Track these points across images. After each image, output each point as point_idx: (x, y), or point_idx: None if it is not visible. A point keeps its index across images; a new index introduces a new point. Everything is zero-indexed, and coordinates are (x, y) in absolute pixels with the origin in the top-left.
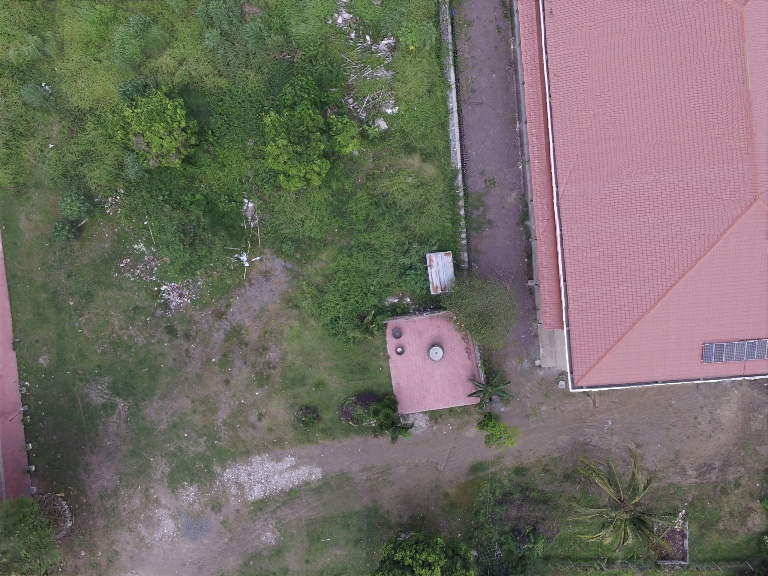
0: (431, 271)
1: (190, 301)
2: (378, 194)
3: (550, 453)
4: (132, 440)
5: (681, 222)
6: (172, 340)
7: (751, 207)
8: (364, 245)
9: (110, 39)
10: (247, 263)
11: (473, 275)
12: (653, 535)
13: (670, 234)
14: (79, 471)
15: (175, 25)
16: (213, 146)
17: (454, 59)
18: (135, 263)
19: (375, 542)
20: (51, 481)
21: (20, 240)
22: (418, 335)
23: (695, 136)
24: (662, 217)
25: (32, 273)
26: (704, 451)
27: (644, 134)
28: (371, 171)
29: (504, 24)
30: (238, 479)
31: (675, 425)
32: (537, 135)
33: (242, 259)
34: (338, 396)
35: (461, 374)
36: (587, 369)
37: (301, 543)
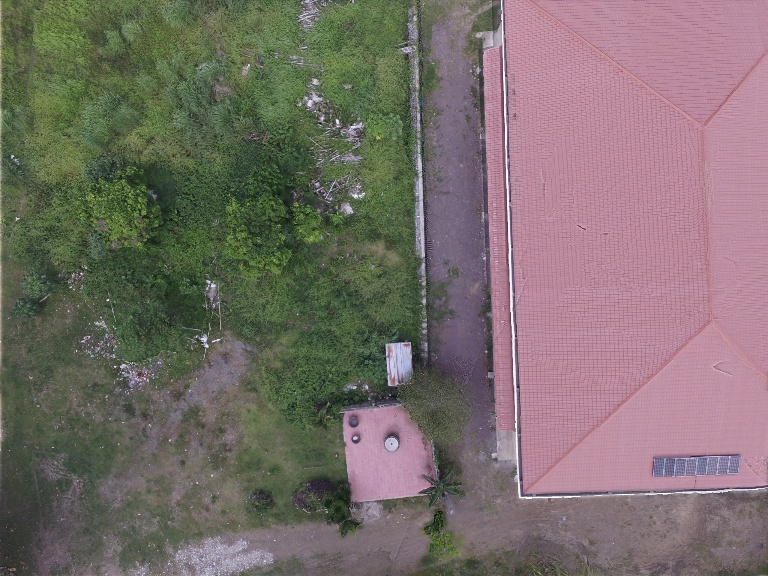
0: (389, 362)
1: (149, 380)
2: (340, 281)
3: (503, 547)
4: (86, 517)
5: (637, 334)
6: (129, 419)
7: (704, 329)
8: (324, 331)
9: (80, 114)
10: (207, 345)
11: (432, 367)
12: None
13: (625, 345)
14: (32, 546)
15: (145, 102)
16: (178, 226)
17: (422, 148)
18: (95, 340)
19: None
20: (3, 555)
21: None
22: (375, 423)
23: None
24: (618, 327)
25: None
26: (658, 551)
27: None
28: (335, 255)
29: (474, 114)
30: (190, 561)
31: (630, 523)
32: (498, 235)
33: (202, 340)
34: (293, 481)
35: (417, 464)
36: (537, 478)
37: None
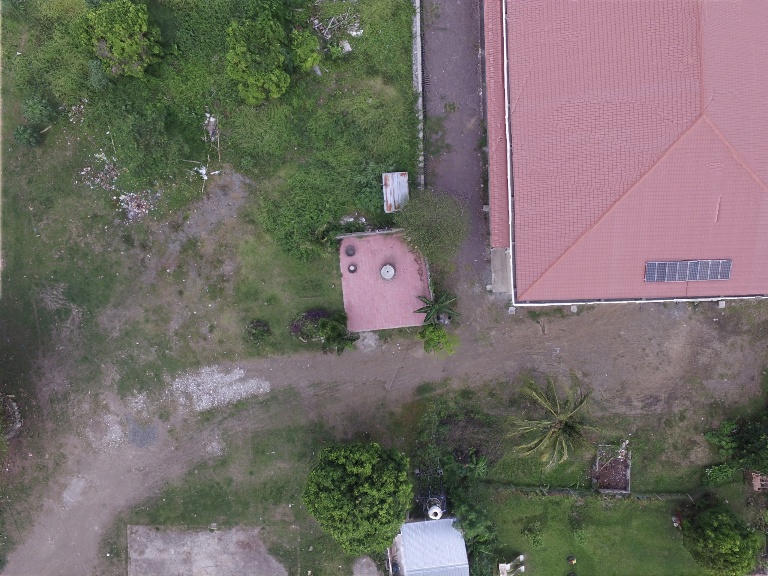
0: (386, 190)
1: (148, 211)
2: (338, 113)
3: (497, 378)
4: (84, 346)
5: (630, 142)
6: (128, 249)
7: (696, 123)
8: (322, 163)
9: None
10: (206, 176)
11: None
12: (583, 441)
13: (619, 153)
14: (31, 374)
15: None
16: (178, 60)
17: None
18: (95, 171)
19: None
20: (2, 382)
21: None
22: (371, 255)
23: (655, 70)
24: (612, 137)
25: None
26: (650, 383)
27: (601, 59)
28: (333, 92)
29: None
30: (187, 389)
31: (623, 356)
32: (494, 55)
33: (201, 172)
34: (290, 312)
35: (412, 295)
36: (530, 283)
37: (246, 455)
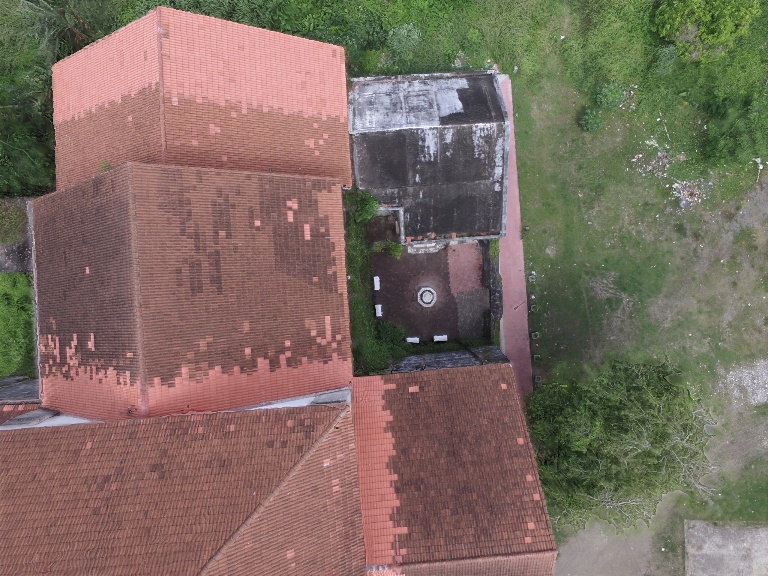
0: None
1: (701, 200)
2: None
3: None
4: (636, 336)
5: None
6: (681, 239)
7: None
8: None
9: None
10: (762, 166)
11: None
12: None
13: None
14: (582, 364)
15: None
16: None
17: None
18: (648, 159)
19: None
20: (554, 372)
21: (531, 129)
22: None
23: None
24: None
25: (542, 163)
26: None
27: None
28: None
29: None
30: (741, 382)
31: None
32: None
33: (757, 161)
34: None
35: None
36: None
37: None
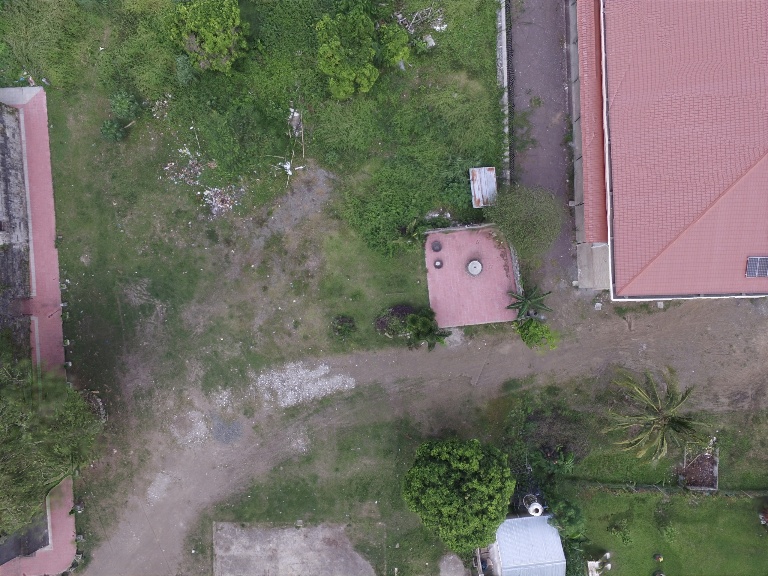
0: (474, 185)
1: (232, 207)
2: (423, 108)
3: (583, 374)
4: (168, 342)
5: (730, 136)
6: (212, 245)
7: None
8: (407, 158)
9: None
10: (290, 171)
11: None
12: (693, 436)
13: (719, 148)
14: (115, 370)
15: None
16: (262, 55)
17: None
18: (179, 167)
19: (405, 453)
20: (87, 378)
21: (67, 139)
22: (457, 250)
23: (742, 64)
24: (711, 131)
25: (77, 172)
26: (738, 379)
27: (694, 53)
28: (417, 87)
29: None
30: (272, 385)
31: (710, 352)
32: (588, 49)
33: (285, 167)
34: (375, 307)
35: (498, 291)
36: (630, 278)
37: (332, 451)
